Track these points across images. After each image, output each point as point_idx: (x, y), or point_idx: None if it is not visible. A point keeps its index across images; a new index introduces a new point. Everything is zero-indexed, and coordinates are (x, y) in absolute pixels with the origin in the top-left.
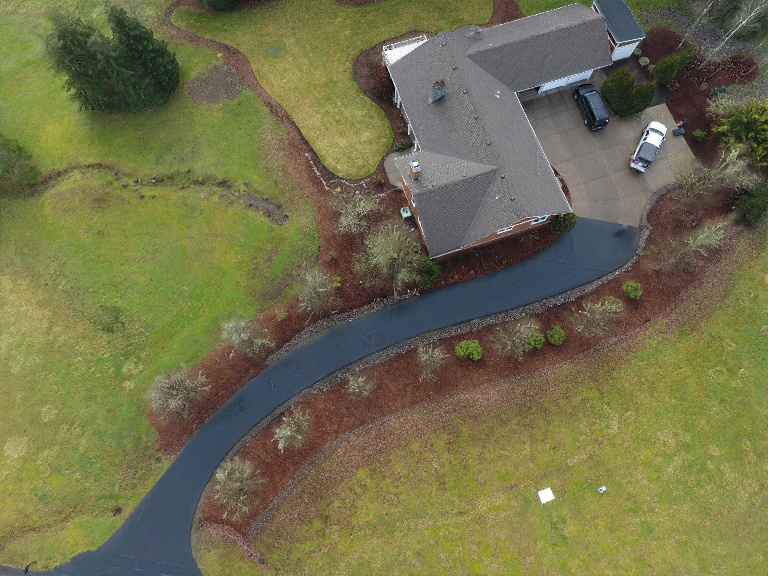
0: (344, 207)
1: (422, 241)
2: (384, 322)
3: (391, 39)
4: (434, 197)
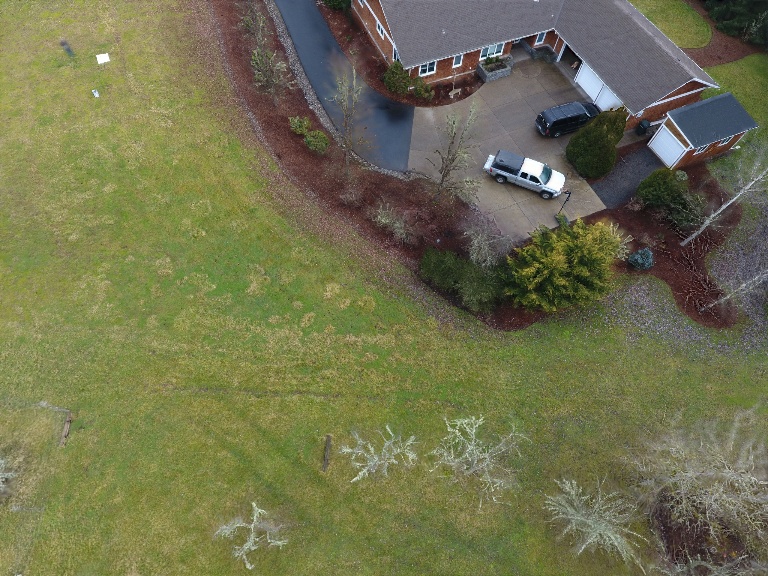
0: None
1: None
2: None
3: None
4: None
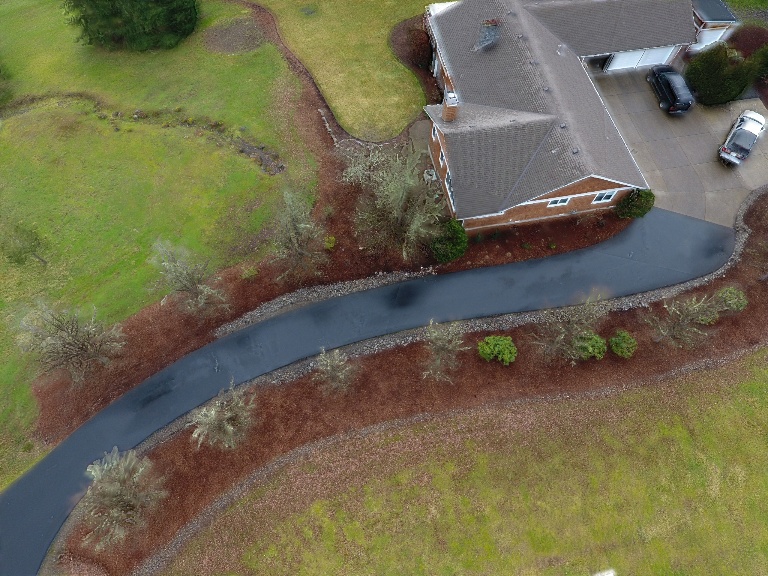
0: (354, 157)
1: (447, 210)
2: (384, 302)
3: None
4: (471, 140)
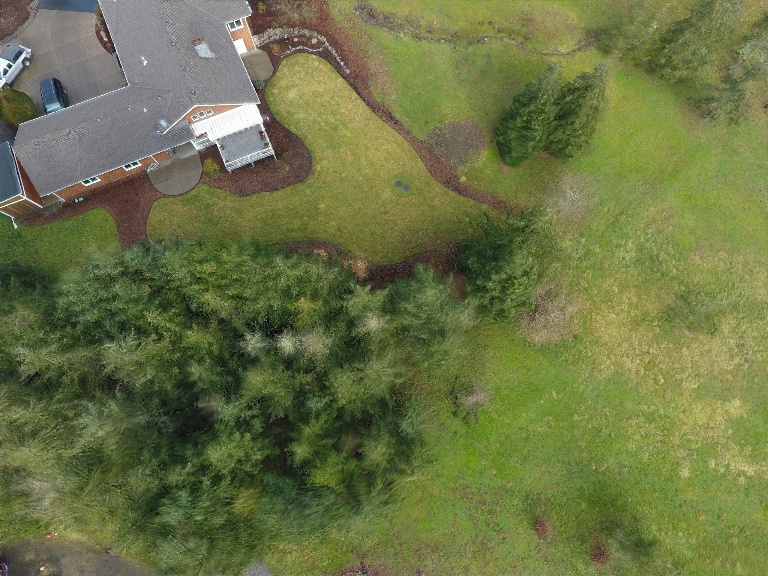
0: None
1: None
2: None
3: (270, 191)
4: None
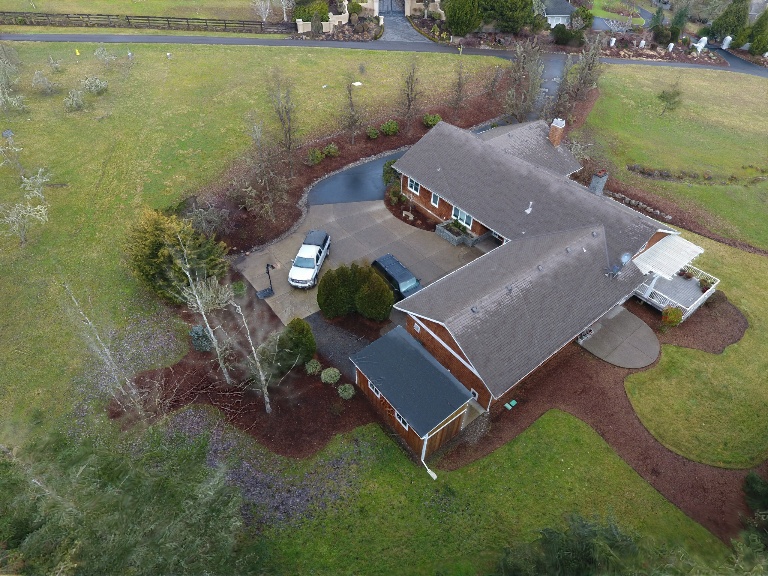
0: None
1: None
2: None
3: (734, 342)
4: None
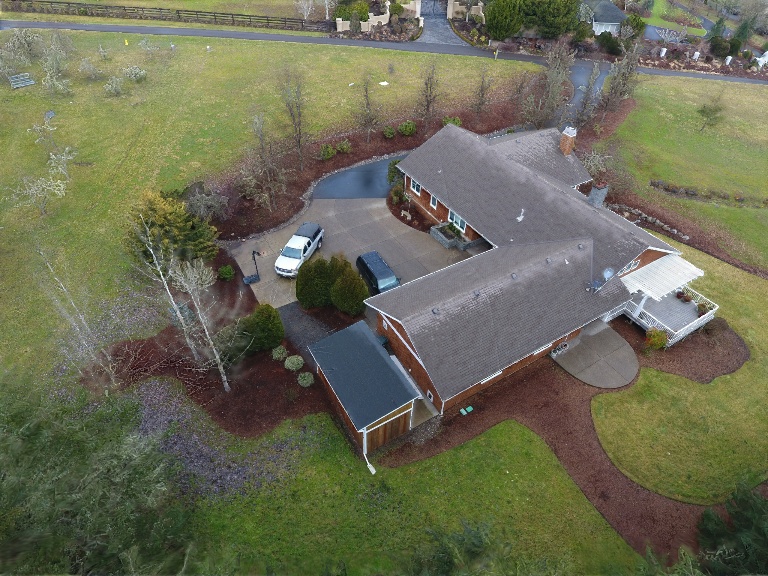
0: None
1: None
2: None
3: (727, 373)
4: None
